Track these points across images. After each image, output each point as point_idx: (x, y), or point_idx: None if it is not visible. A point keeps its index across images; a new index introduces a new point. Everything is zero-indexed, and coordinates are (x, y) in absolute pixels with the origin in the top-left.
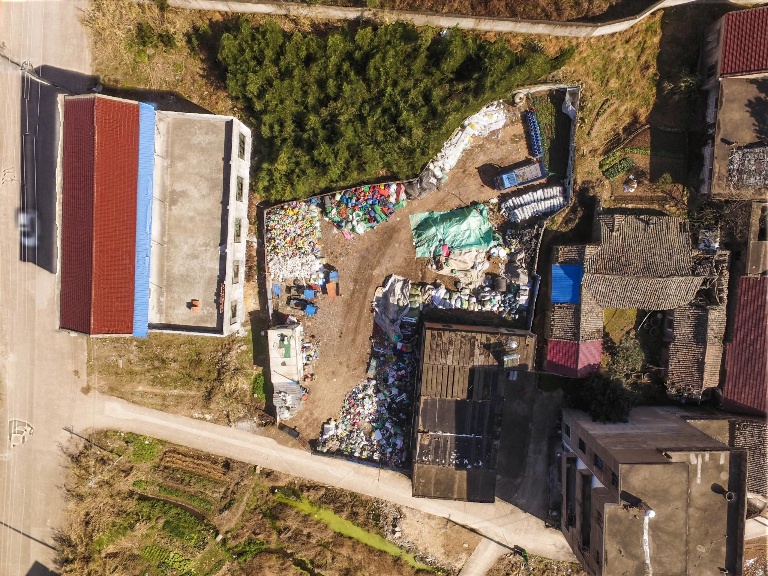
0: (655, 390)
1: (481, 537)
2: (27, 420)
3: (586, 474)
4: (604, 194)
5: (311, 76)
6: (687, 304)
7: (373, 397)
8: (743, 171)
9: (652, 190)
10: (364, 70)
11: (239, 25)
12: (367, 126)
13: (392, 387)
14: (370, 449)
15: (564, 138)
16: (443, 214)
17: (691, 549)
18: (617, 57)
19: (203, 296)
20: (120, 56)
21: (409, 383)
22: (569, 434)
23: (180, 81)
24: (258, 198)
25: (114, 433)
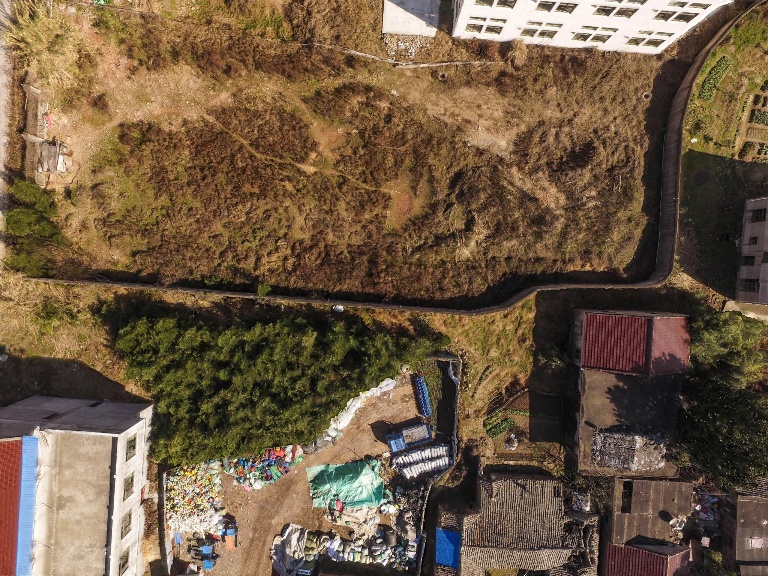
0: None
1: None
2: None
3: None
4: (487, 452)
5: (204, 366)
6: (561, 566)
7: None
8: (605, 453)
9: (532, 448)
10: (256, 354)
11: (143, 298)
12: (256, 415)
13: None
14: None
15: (451, 399)
16: (338, 467)
17: None
18: (497, 329)
19: None
20: (26, 328)
21: None
22: None
23: (84, 350)
24: None
25: None
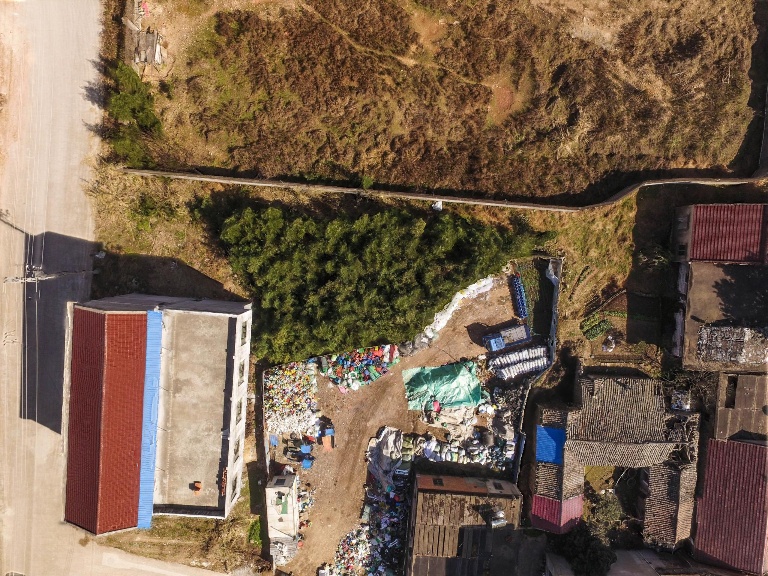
0: (632, 536)
1: None
2: (24, 572)
3: None
4: (585, 354)
5: (310, 257)
6: (661, 462)
7: (366, 543)
8: (711, 347)
9: (629, 350)
10: (360, 248)
11: (240, 195)
12: (363, 306)
13: (385, 534)
14: None
15: (547, 300)
16: (434, 369)
17: None
18: (596, 229)
19: (205, 478)
20: (123, 224)
21: (401, 528)
22: None
23: (182, 248)
24: None
25: None
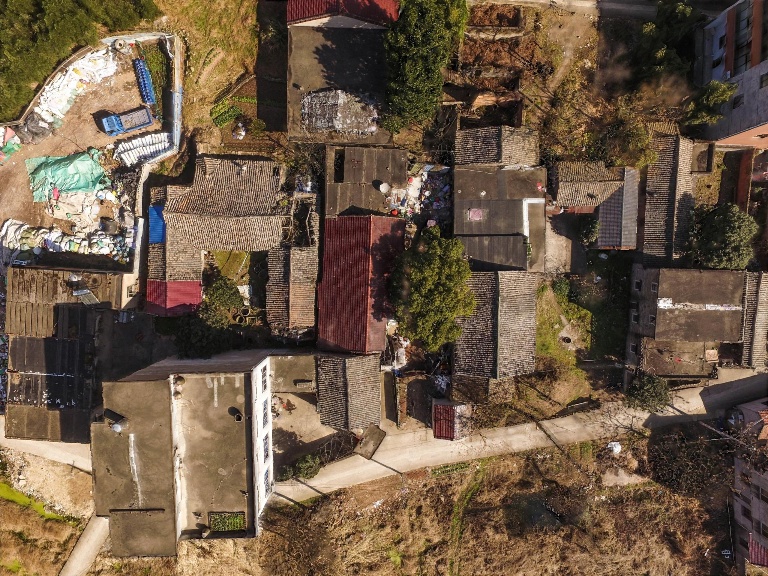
0: (266, 333)
1: None
2: None
3: None
4: (213, 141)
5: None
6: (278, 245)
7: None
8: (312, 115)
9: (260, 138)
10: None
11: None
12: None
13: None
14: None
15: None
16: (59, 159)
17: (213, 473)
18: (218, 8)
19: None
20: None
21: None
22: None
23: None
24: None
25: None
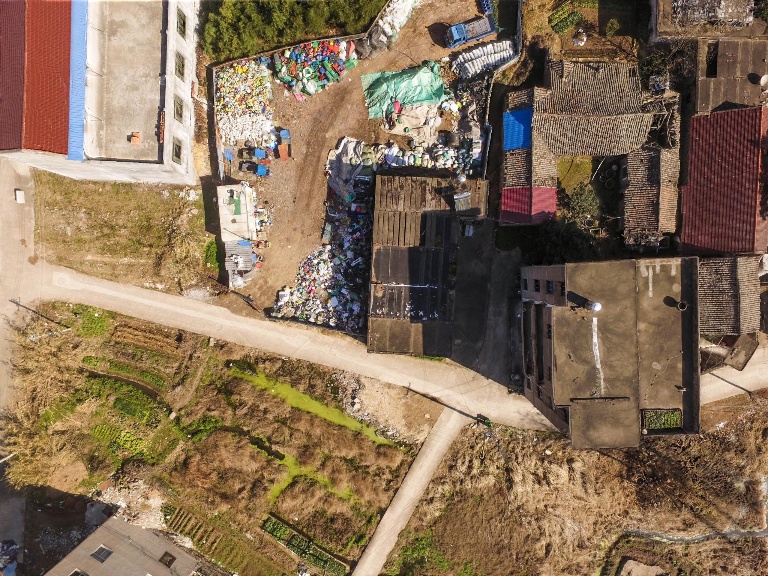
0: (613, 244)
1: (443, 407)
2: None
3: (539, 304)
4: (554, 48)
5: None
6: (640, 148)
7: (328, 262)
8: (687, 6)
9: (602, 43)
10: None
11: None
12: None
13: (347, 250)
14: (326, 316)
15: None
16: (395, 74)
17: (646, 367)
18: None
19: (144, 128)
20: None
21: (365, 248)
22: (526, 286)
23: None
24: (208, 59)
25: (62, 304)
